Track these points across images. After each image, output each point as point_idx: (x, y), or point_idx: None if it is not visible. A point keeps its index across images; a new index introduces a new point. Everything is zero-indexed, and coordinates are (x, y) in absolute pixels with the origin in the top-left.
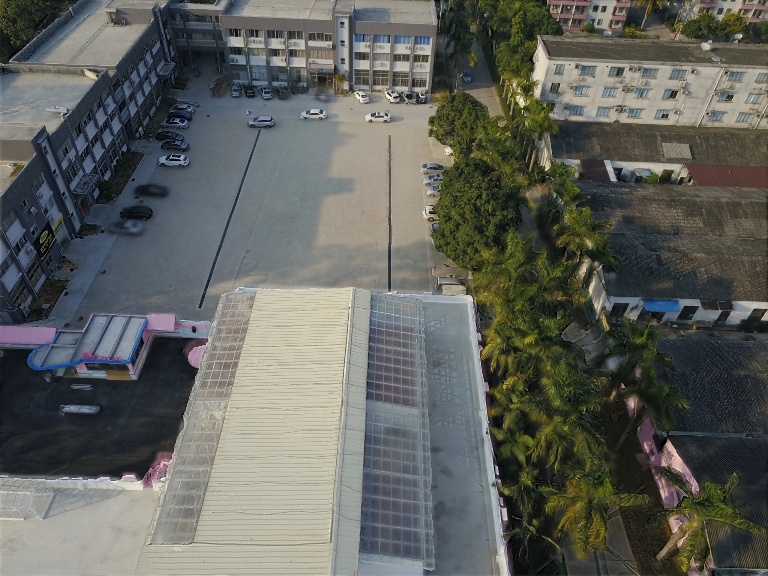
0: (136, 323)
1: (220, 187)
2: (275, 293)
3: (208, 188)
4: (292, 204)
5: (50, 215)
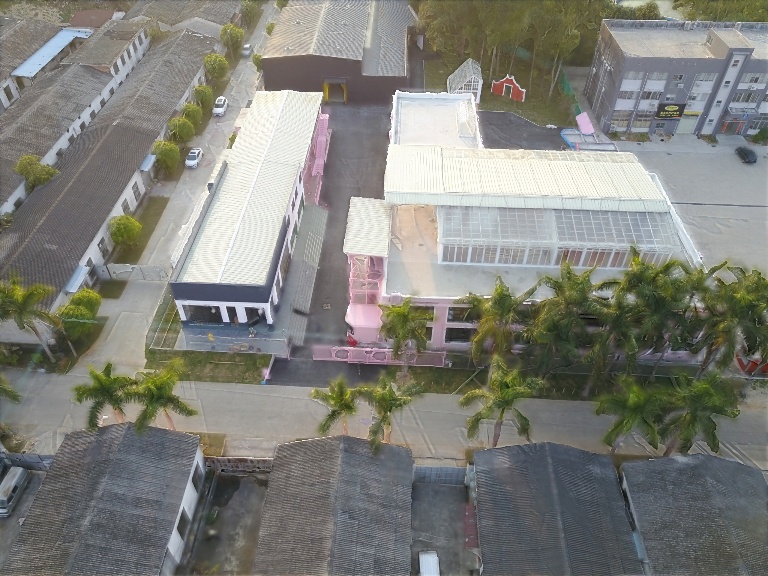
0: None
1: None
2: (641, 169)
3: None
4: None
5: (693, 103)
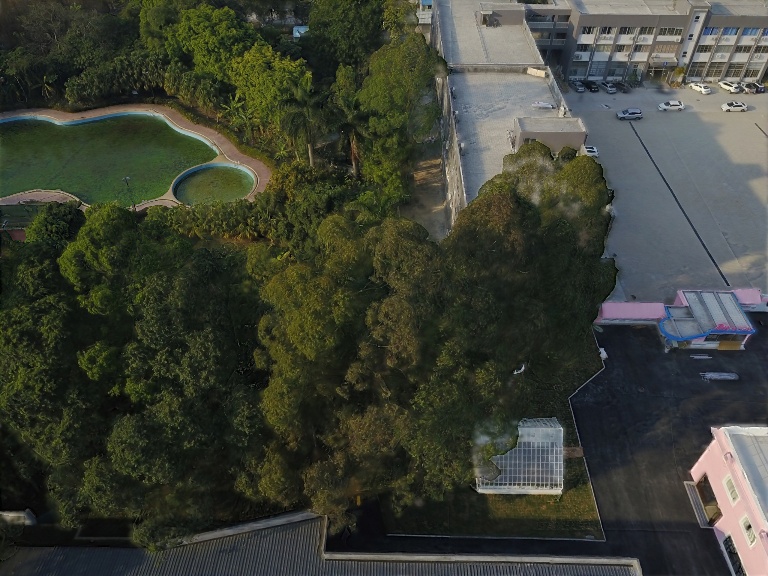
0: (726, 298)
1: (643, 176)
2: None
3: (633, 177)
4: (726, 189)
5: None
